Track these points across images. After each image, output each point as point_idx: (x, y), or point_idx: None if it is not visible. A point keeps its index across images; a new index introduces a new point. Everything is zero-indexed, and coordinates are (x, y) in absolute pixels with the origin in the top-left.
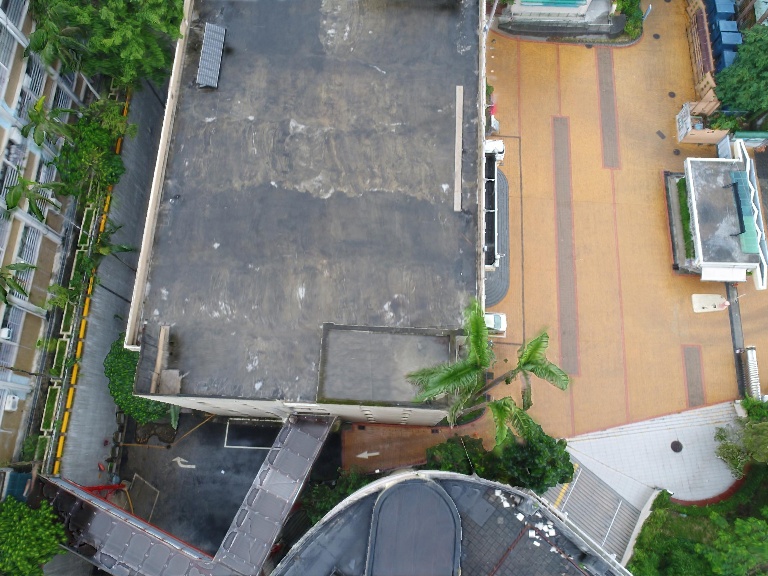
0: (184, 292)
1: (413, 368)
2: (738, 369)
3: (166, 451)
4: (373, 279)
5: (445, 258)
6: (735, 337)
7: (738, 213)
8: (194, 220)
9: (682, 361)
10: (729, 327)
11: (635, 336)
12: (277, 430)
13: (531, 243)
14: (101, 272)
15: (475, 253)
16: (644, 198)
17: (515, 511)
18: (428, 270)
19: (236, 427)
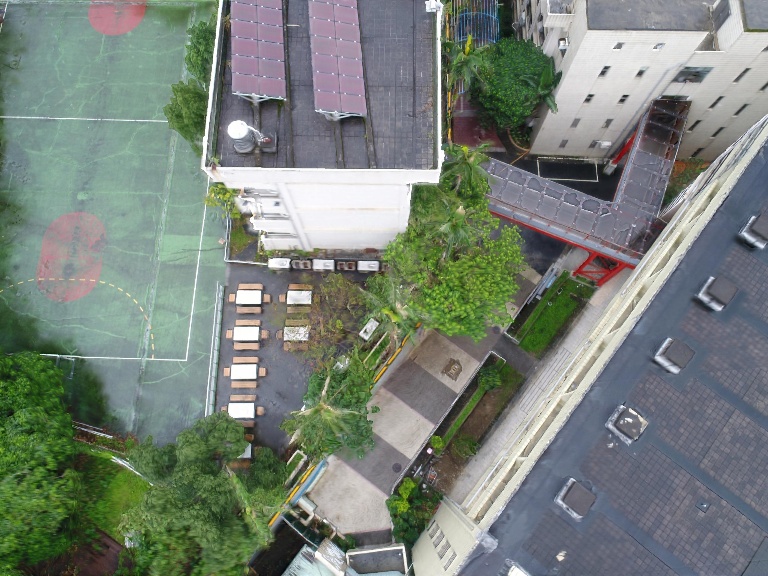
0: None
1: None
2: None
3: None
4: None
5: None
6: None
7: None
8: None
9: None
10: None
11: None
12: (581, 166)
13: None
14: None
15: None
16: None
17: None
18: None
19: (545, 164)
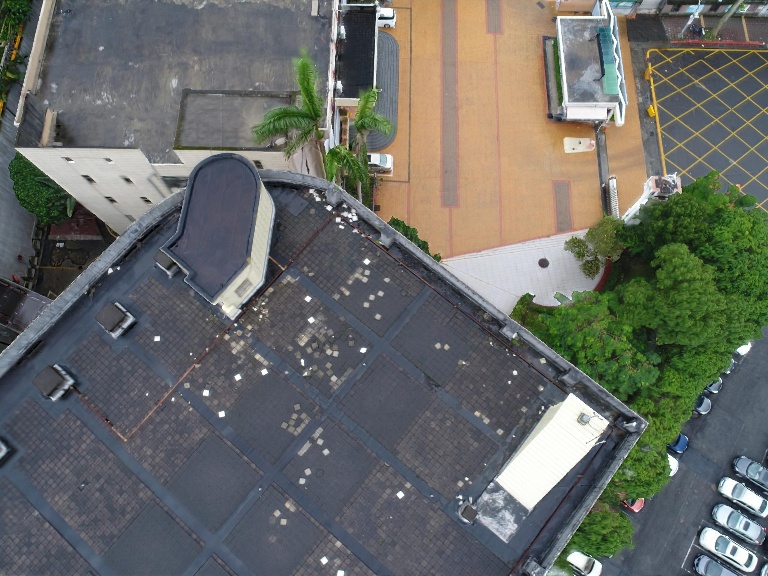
0: (71, 86)
1: (258, 121)
2: (603, 200)
3: (78, 272)
4: (238, 71)
5: (302, 53)
6: (602, 174)
7: (600, 60)
8: (82, 29)
9: (552, 194)
10: (597, 165)
11: (510, 173)
12: None
13: (418, 97)
14: (12, 101)
15: (328, 49)
16: (523, 58)
17: (325, 204)
18: (286, 63)
19: None
